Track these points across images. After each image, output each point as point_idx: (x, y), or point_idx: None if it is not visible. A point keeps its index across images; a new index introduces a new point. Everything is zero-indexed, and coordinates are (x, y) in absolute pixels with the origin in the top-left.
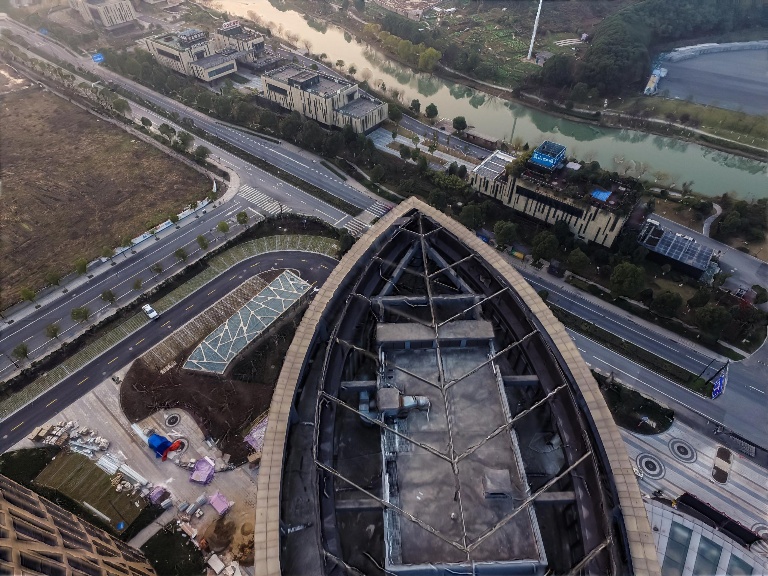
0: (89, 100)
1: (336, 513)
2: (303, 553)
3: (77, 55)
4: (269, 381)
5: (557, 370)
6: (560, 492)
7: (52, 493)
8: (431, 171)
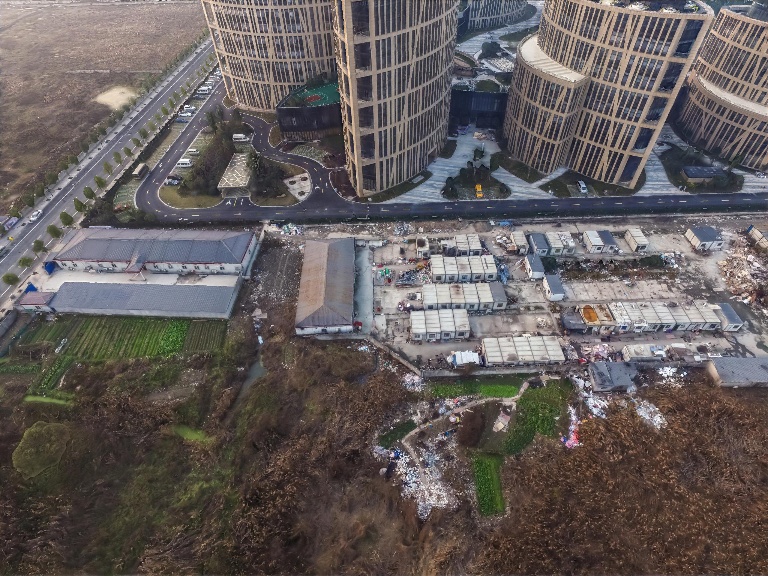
0: None
1: None
2: None
3: None
4: None
5: None
6: None
7: None
8: None
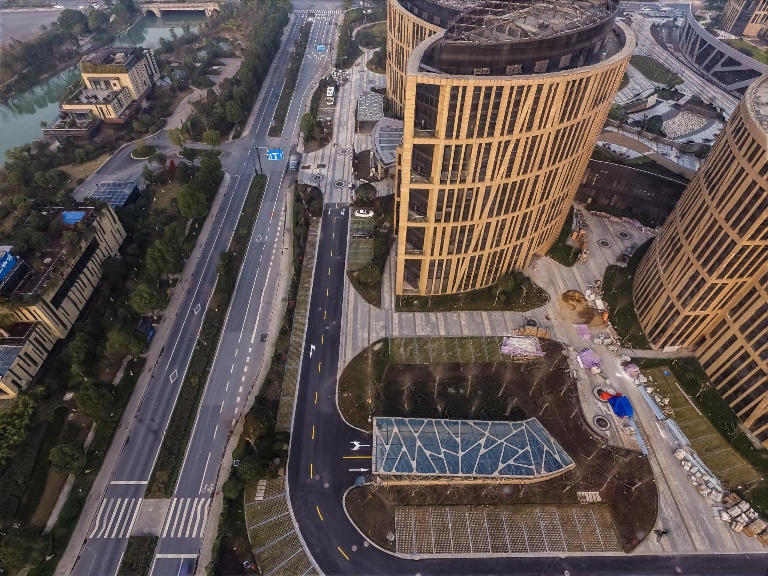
0: None
1: None
2: None
3: None
4: (493, 380)
5: (485, 3)
6: (520, 9)
7: (735, 442)
8: None
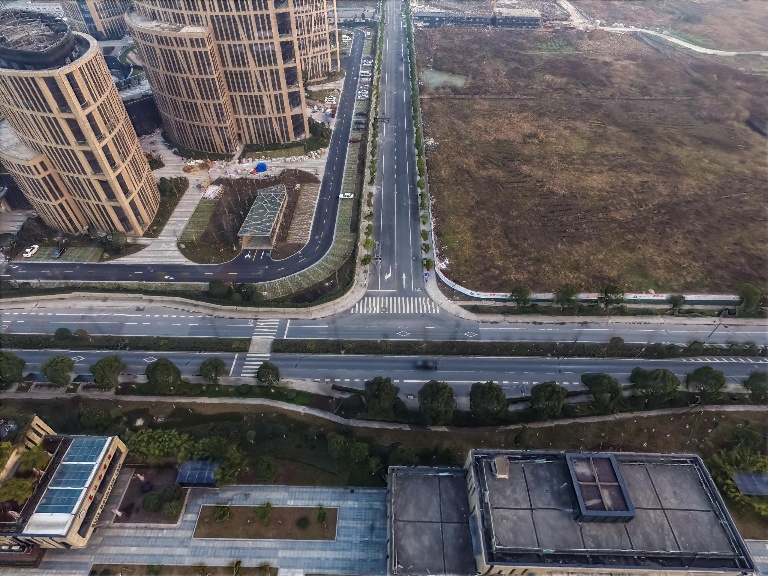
0: None
1: (57, 25)
2: (79, 46)
3: None
4: None
5: None
6: None
7: (288, 146)
8: (200, 447)
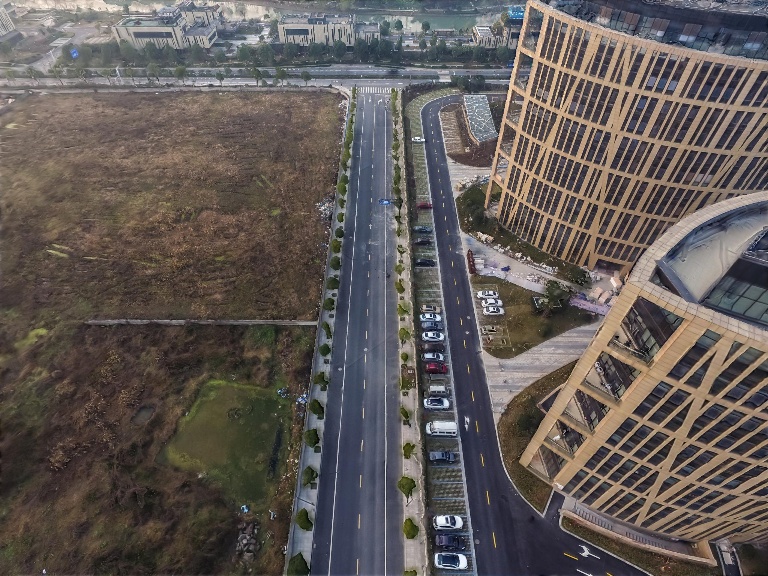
0: (114, 86)
1: None
2: None
3: (6, 67)
4: None
5: None
6: None
7: None
8: (450, 47)
